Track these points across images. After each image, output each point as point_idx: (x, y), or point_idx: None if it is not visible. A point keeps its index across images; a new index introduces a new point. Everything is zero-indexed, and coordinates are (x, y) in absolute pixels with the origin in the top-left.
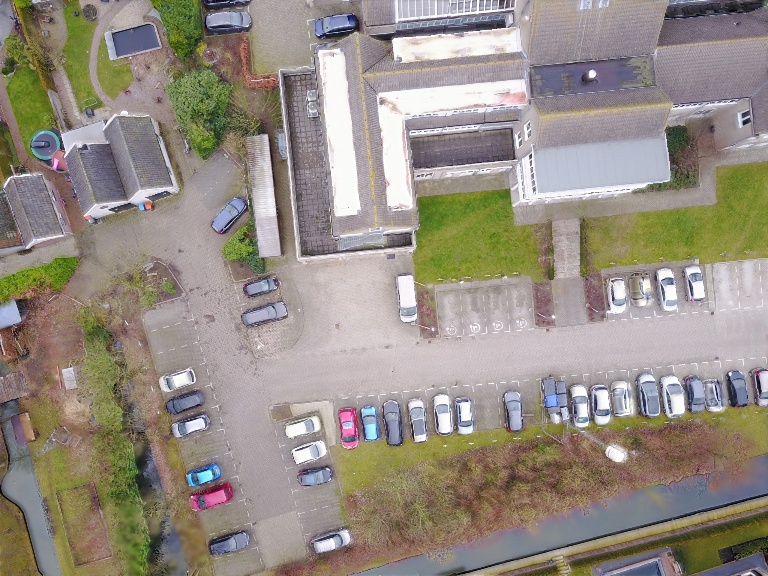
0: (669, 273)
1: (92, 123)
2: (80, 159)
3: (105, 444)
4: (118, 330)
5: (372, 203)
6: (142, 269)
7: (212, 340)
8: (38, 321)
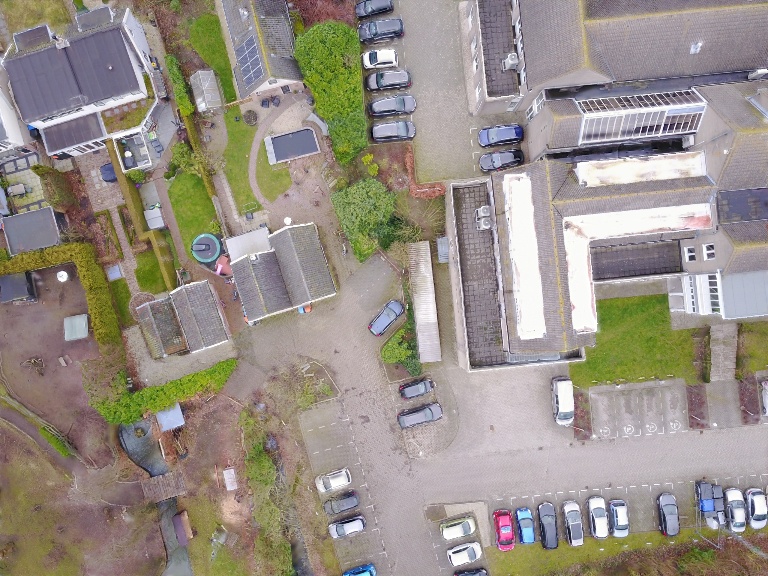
0: None
1: (256, 229)
2: (252, 270)
3: (268, 547)
4: (274, 429)
5: (562, 329)
6: (299, 370)
7: (367, 440)
8: (196, 420)
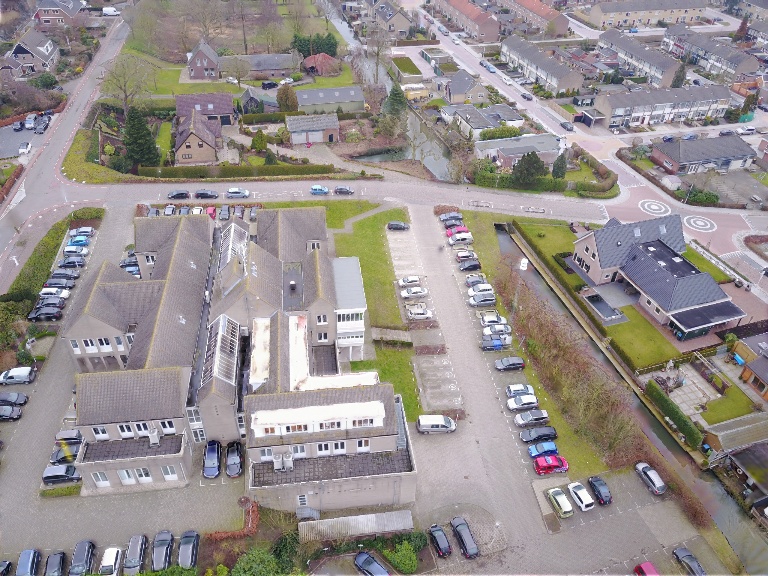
0: (404, 291)
1: None
2: None
3: None
4: None
5: (376, 387)
6: None
7: None
8: None
